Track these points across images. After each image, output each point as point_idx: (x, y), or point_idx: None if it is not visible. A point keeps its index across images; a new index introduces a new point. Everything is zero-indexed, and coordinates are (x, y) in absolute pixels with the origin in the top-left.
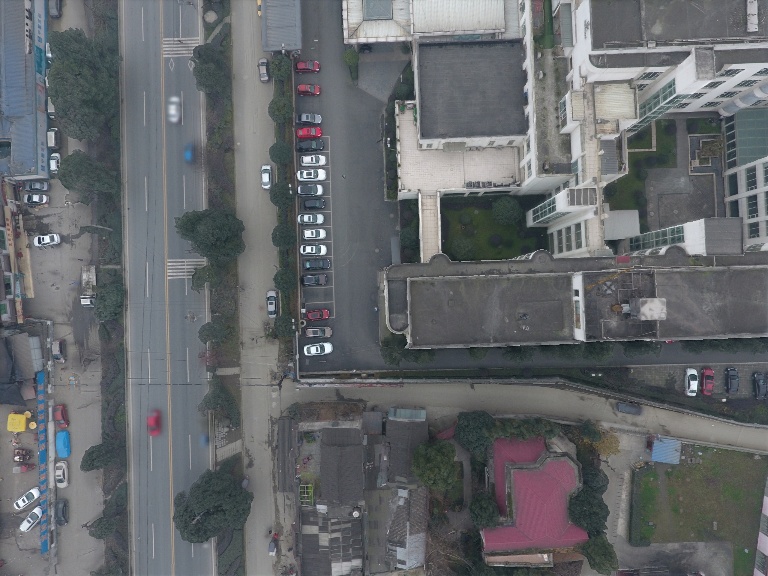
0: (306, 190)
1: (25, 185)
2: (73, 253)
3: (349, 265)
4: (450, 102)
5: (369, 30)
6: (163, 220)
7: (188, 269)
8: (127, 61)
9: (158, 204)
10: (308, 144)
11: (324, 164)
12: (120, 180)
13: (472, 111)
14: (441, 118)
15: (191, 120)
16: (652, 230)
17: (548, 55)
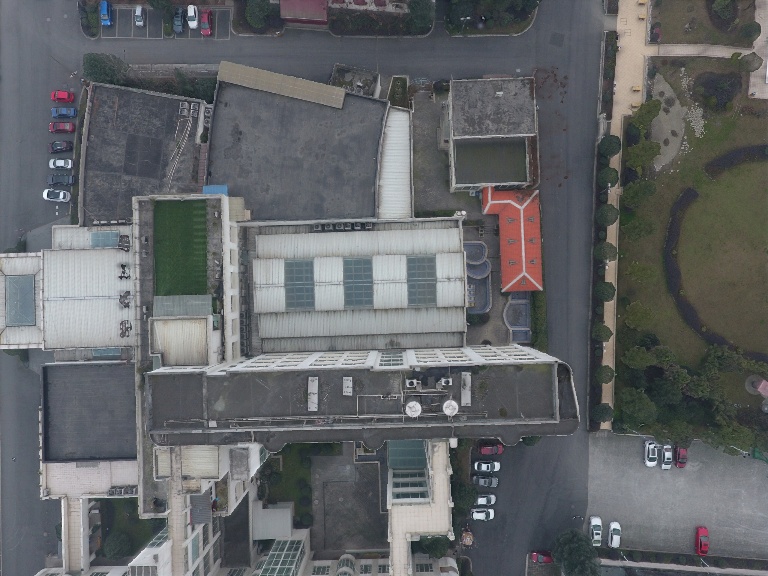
0: None
1: None
2: None
3: (17, 549)
4: (79, 421)
5: (12, 336)
6: None
7: None
8: None
9: None
10: None
11: None
12: None
13: (101, 430)
14: (70, 436)
15: None
16: (317, 518)
17: None
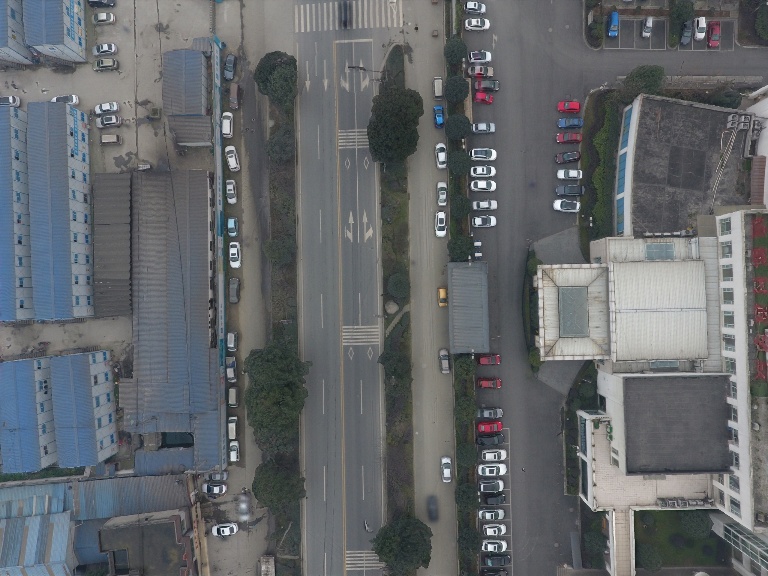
0: (489, 489)
1: (204, 473)
2: (250, 540)
3: (528, 559)
4: (653, 433)
5: (565, 348)
6: (342, 511)
7: (366, 561)
8: (306, 348)
9: (337, 494)
10: (490, 440)
11: (504, 458)
12: (299, 470)
13: (675, 443)
14: (644, 449)
15: (370, 409)
16: None
17: (762, 403)
